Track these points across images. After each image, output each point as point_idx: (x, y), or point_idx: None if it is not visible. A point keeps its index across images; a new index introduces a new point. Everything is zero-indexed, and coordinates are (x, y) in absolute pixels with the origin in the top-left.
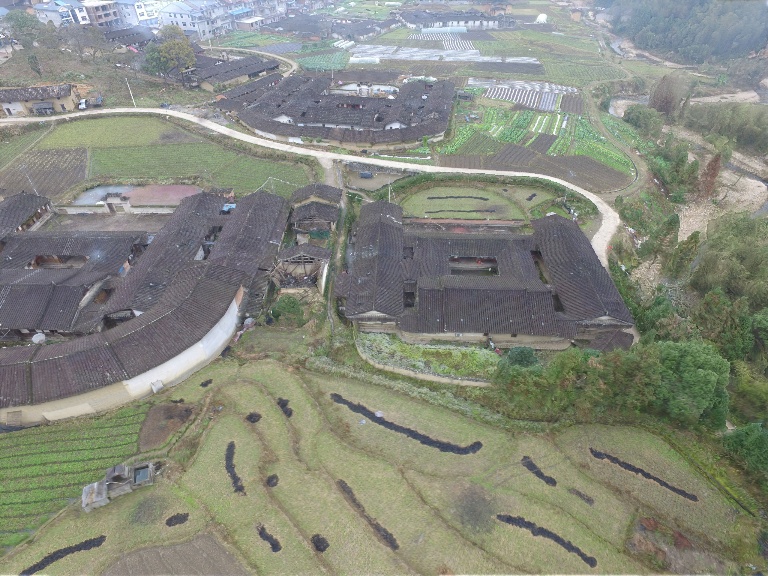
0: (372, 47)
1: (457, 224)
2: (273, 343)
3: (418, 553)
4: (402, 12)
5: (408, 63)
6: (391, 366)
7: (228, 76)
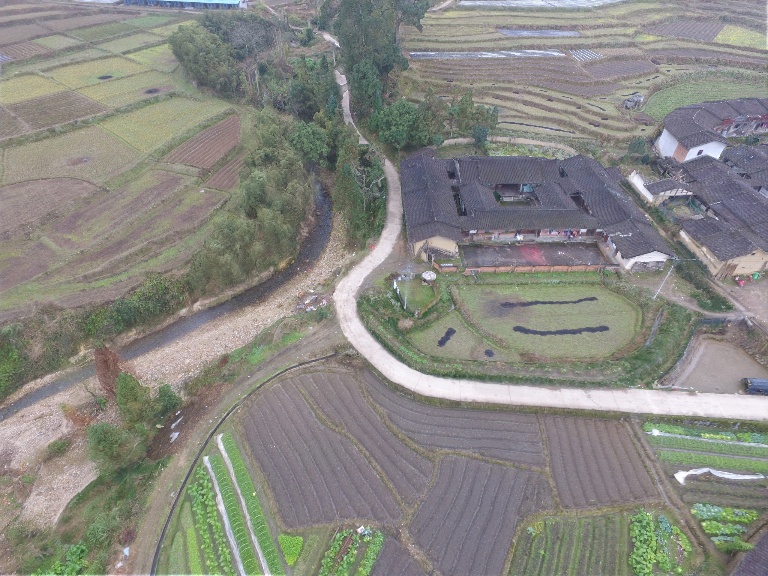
0: None
1: (547, 271)
2: None
3: (515, 103)
4: None
5: None
6: (552, 141)
7: None
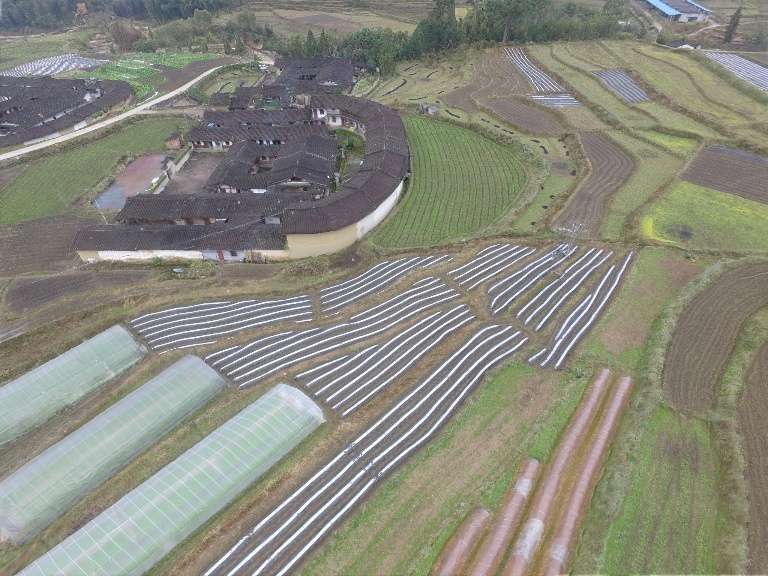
0: None
1: None
2: None
3: None
4: None
5: None
6: None
7: None
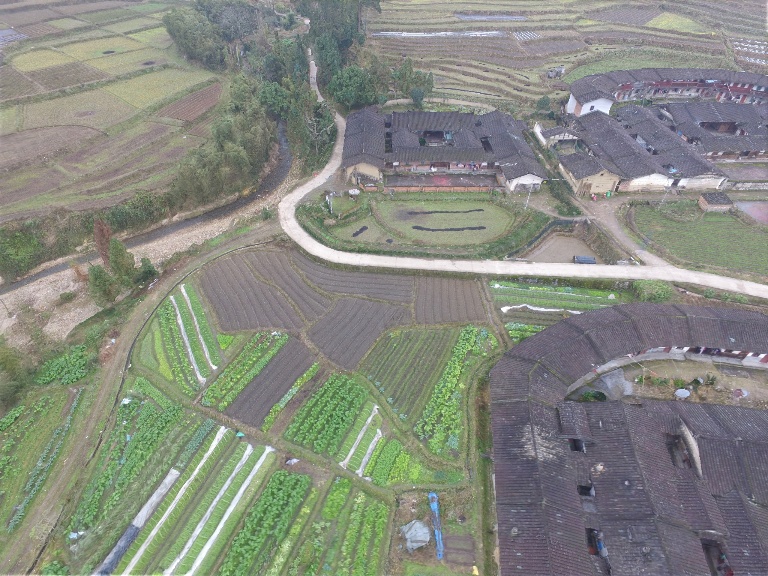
0: None
1: (449, 191)
2: (542, 110)
3: None
4: None
5: None
6: None
7: None
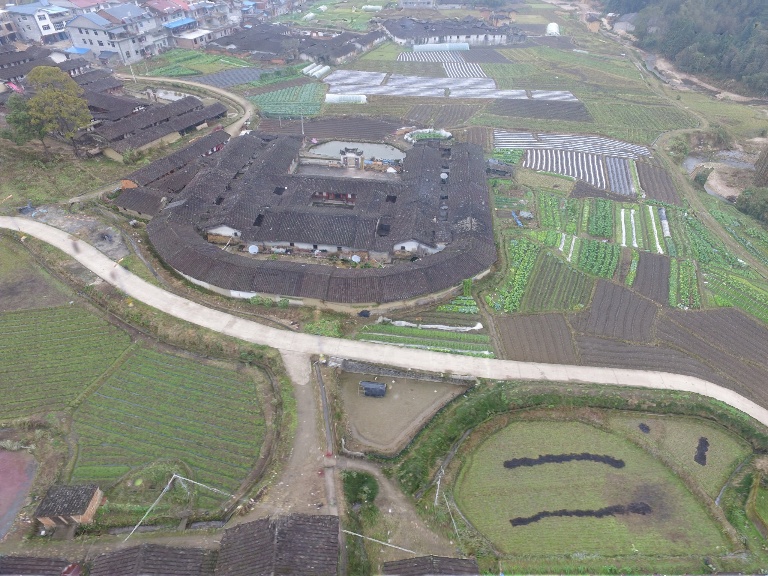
0: (353, 74)
1: None
2: None
3: None
4: (385, 21)
5: (405, 102)
6: None
7: (147, 137)
